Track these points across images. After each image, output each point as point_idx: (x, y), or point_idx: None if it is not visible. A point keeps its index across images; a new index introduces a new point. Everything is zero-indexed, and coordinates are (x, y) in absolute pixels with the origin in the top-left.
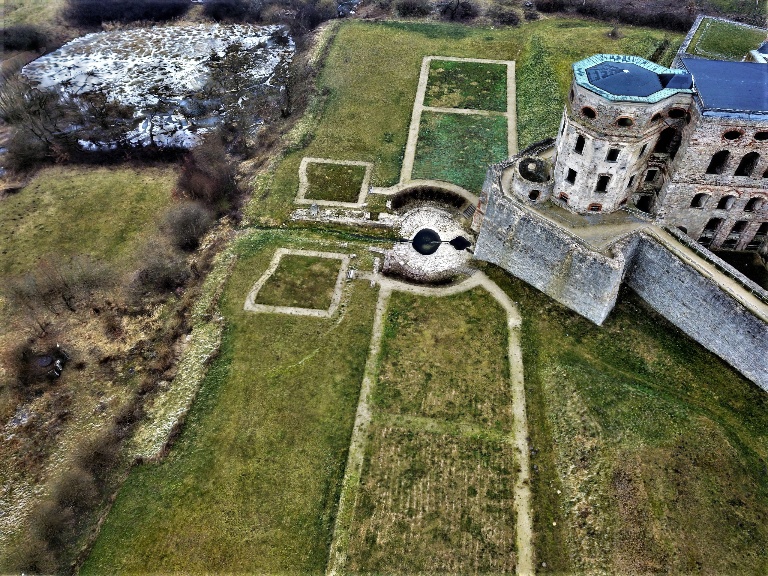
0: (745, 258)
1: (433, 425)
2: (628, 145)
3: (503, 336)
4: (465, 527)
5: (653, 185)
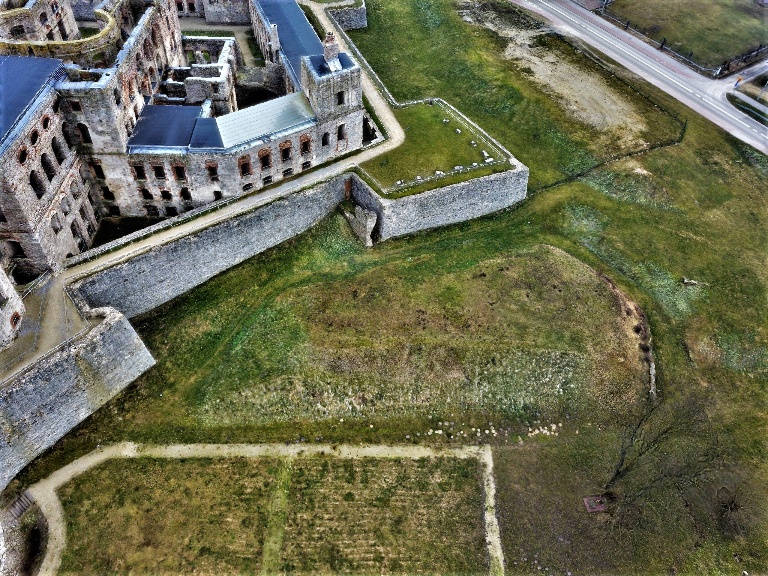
0: (108, 227)
1: (273, 542)
2: None
3: (149, 463)
4: (385, 503)
5: (7, 257)
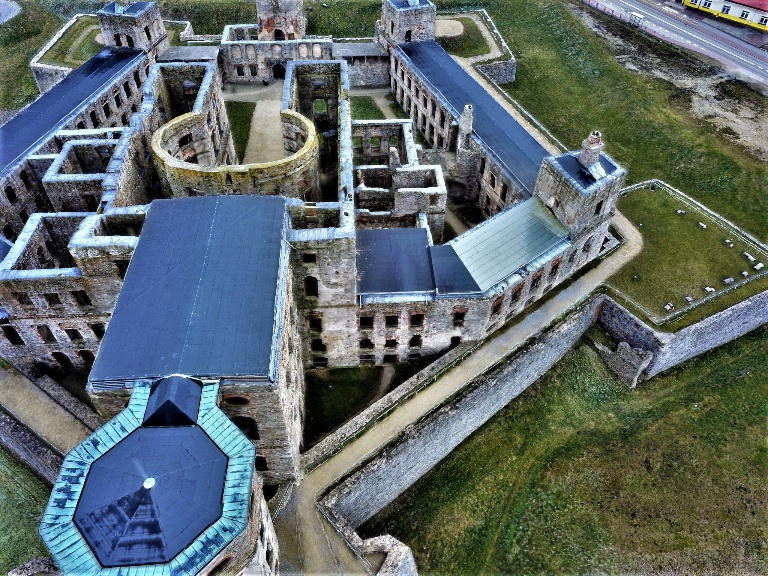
0: (317, 385)
1: None
2: (261, 503)
3: None
4: None
5: None
